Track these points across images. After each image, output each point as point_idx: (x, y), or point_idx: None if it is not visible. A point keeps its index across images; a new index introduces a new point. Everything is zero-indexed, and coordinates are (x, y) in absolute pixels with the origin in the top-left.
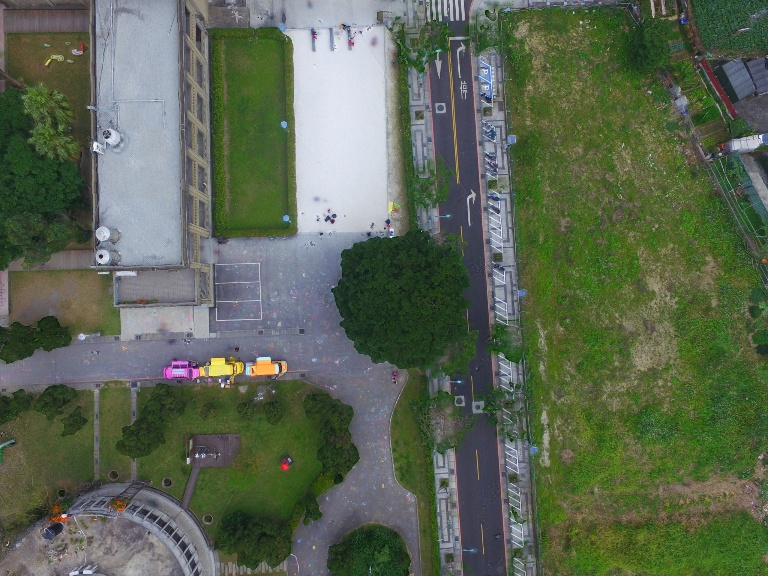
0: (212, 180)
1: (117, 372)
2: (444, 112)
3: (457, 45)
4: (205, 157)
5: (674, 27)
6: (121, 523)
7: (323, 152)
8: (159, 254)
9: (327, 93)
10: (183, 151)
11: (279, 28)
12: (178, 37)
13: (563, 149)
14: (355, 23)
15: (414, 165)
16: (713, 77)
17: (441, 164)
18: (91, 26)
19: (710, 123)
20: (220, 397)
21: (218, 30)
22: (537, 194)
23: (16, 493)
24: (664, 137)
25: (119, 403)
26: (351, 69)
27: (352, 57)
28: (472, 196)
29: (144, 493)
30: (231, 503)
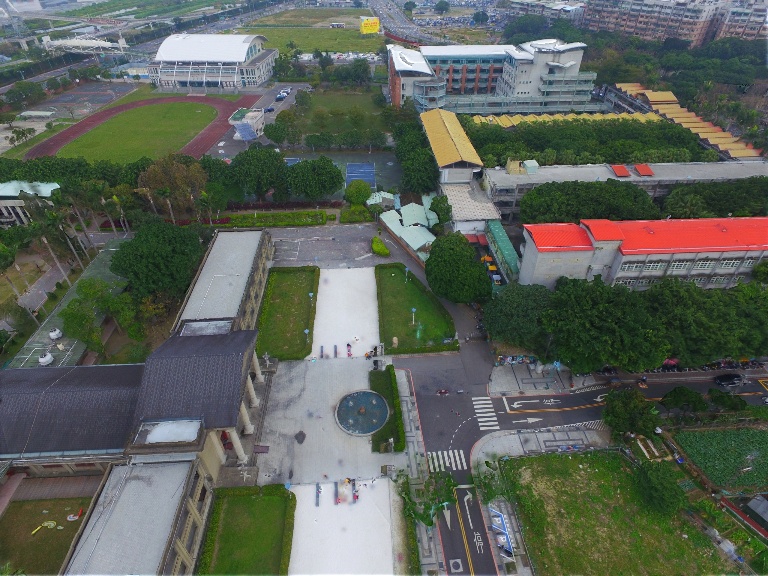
0: None
1: None
2: (461, 571)
3: (463, 493)
4: None
5: (674, 467)
6: None
7: None
8: None
9: (327, 552)
10: None
11: None
12: (179, 502)
13: None
14: (360, 476)
15: None
16: (744, 516)
17: None
18: (96, 495)
19: None
20: None
21: (224, 489)
22: None
23: None
24: None
25: None
26: (355, 523)
27: (356, 510)
28: None
29: None
30: None
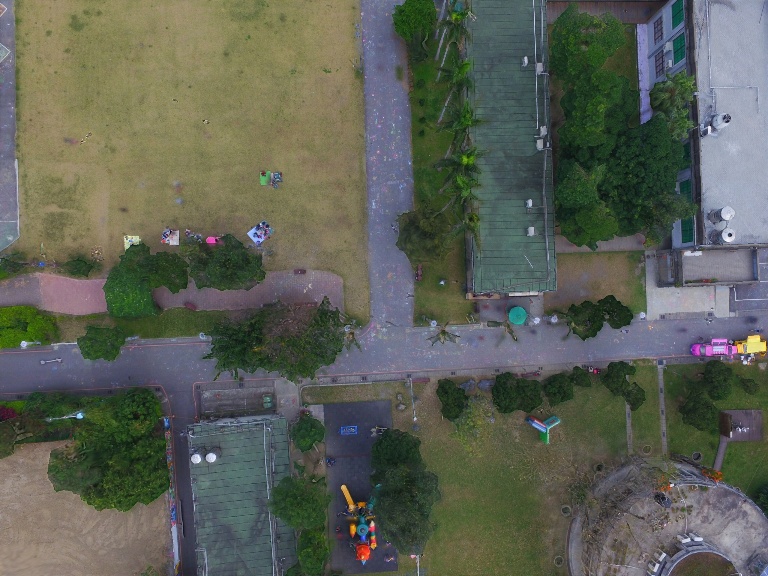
0: None
1: (645, 350)
2: None
3: None
4: None
5: None
6: (716, 492)
7: None
8: (756, 233)
9: None
10: None
11: None
12: None
13: None
14: None
15: None
16: None
17: None
18: None
19: None
20: (742, 374)
21: None
22: None
23: (557, 468)
24: None
25: (648, 380)
26: None
27: None
28: None
29: (678, 467)
30: (756, 476)
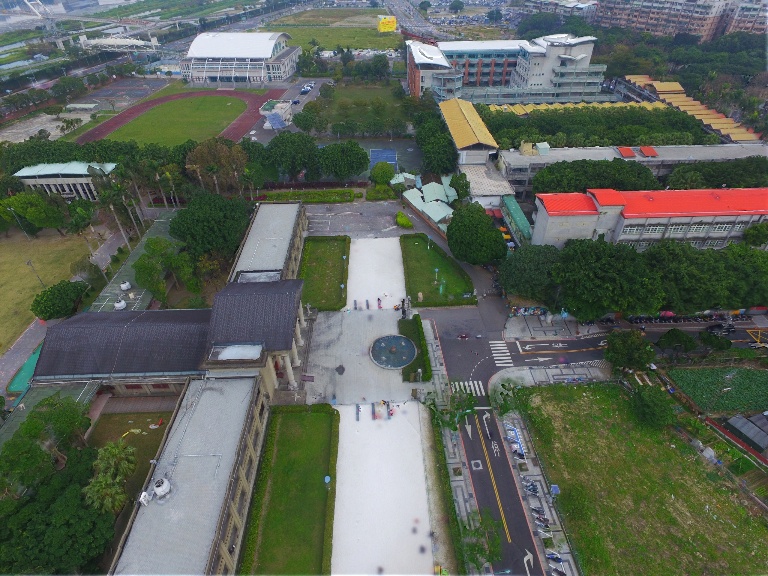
0: (242, 543)
1: None
2: (481, 468)
3: (482, 413)
4: (241, 517)
5: None
6: None
7: (362, 510)
8: None
9: (368, 454)
10: (226, 501)
11: (329, 404)
12: (248, 405)
13: (611, 502)
14: (393, 399)
15: (458, 522)
16: (725, 431)
17: (487, 521)
18: (180, 399)
19: (750, 473)
20: None
21: (278, 407)
22: (602, 553)
23: None
24: (711, 488)
25: None
26: (390, 434)
27: (391, 424)
28: (529, 557)
29: None
30: None
